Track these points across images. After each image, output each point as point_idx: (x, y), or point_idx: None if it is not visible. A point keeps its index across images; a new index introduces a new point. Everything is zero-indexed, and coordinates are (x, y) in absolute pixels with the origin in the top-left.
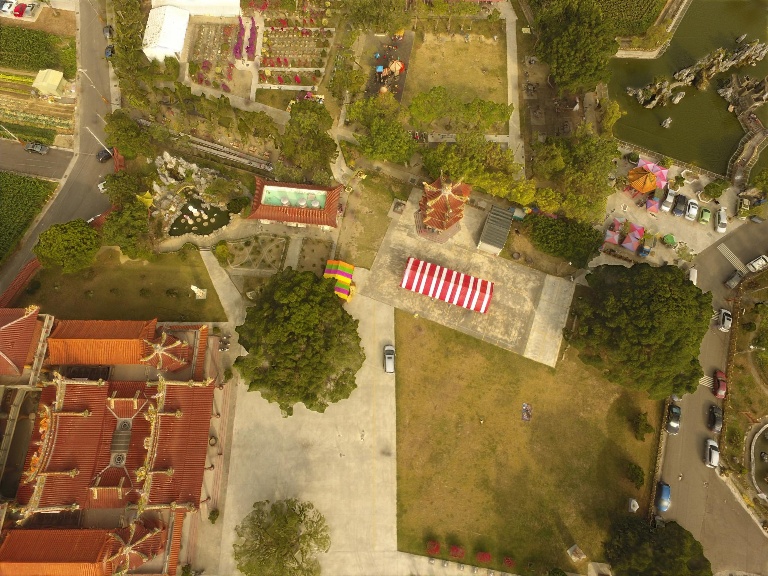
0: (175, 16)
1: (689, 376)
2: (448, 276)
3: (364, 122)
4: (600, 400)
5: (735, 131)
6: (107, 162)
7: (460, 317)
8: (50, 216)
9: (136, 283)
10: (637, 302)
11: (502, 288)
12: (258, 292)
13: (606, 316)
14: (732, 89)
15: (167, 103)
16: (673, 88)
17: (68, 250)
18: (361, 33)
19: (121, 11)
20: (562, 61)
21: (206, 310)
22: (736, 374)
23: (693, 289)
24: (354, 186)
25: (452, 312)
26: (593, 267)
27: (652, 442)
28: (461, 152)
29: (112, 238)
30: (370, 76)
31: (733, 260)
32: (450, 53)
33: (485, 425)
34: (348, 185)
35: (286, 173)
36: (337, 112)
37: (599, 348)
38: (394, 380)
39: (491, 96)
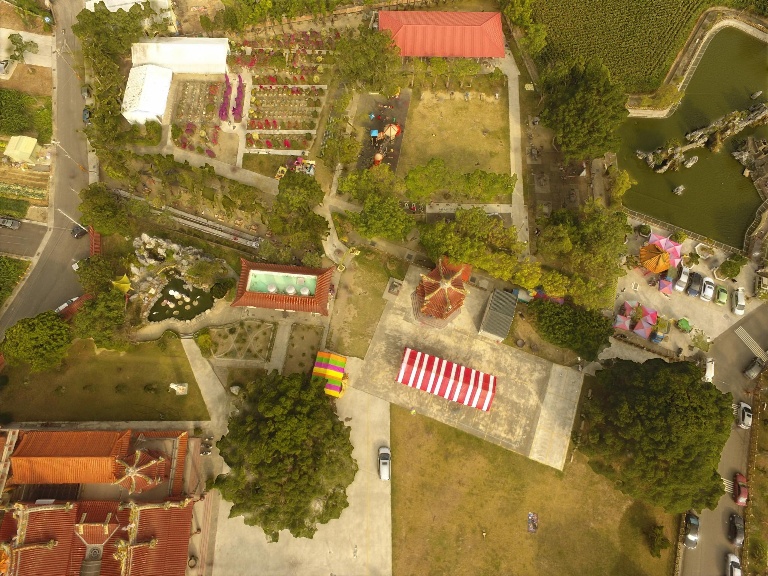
0: (157, 76)
1: (709, 492)
2: (447, 370)
3: (357, 196)
4: (612, 508)
5: (751, 198)
6: (83, 237)
7: (460, 413)
8: (21, 299)
9: (112, 377)
10: (653, 412)
11: (505, 379)
12: (241, 400)
13: (619, 425)
14: (748, 153)
15: (148, 172)
16: (685, 151)
17: (36, 348)
18: (354, 93)
19: (97, 76)
20: (569, 130)
21: (187, 407)
22: (757, 477)
23: (713, 393)
24: (347, 263)
25: (452, 407)
26: (603, 360)
27: (668, 557)
28: (461, 231)
29: (85, 331)
30: (364, 139)
31: (752, 346)
32: (449, 113)
33: (488, 538)
34: (340, 265)
35: (274, 253)
36: (329, 179)
37: (611, 458)
38: (389, 487)
39: (493, 161)
